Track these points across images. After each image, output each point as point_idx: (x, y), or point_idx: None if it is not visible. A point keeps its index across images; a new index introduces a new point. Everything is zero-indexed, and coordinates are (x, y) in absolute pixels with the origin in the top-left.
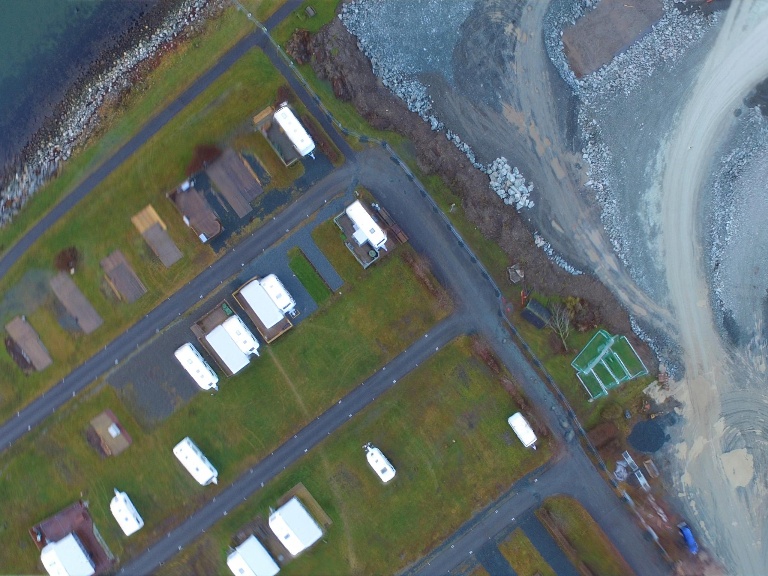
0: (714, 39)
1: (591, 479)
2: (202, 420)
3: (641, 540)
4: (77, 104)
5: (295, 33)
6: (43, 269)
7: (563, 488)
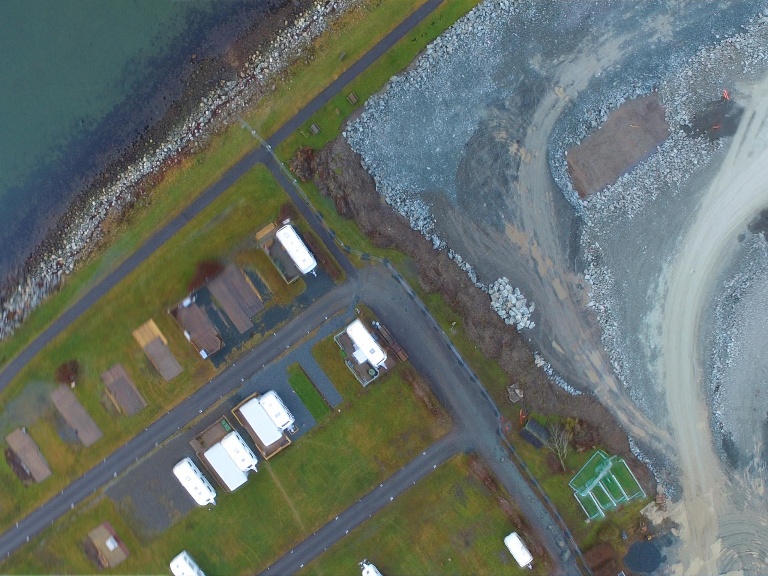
0: (719, 164)
1: None
2: (199, 534)
3: None
4: (81, 217)
5: (299, 151)
6: (44, 381)
7: None
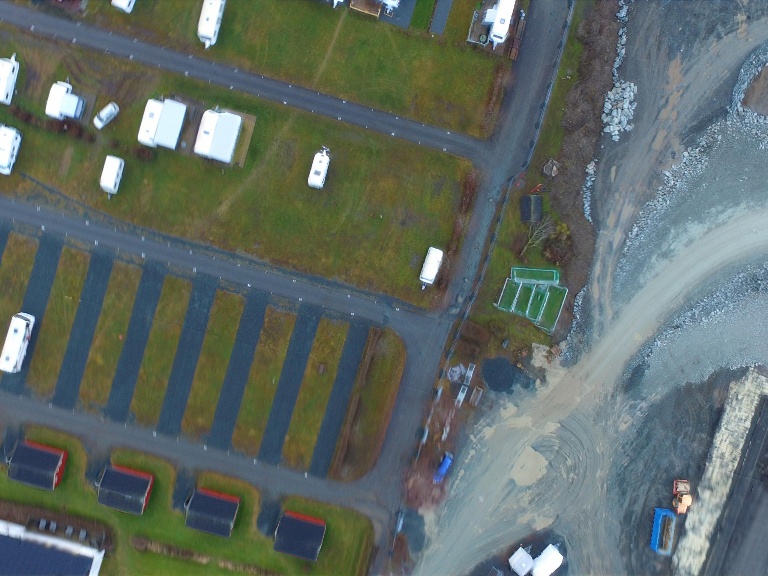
0: None
1: (432, 353)
2: None
3: (412, 431)
4: None
5: None
6: None
7: (408, 336)
